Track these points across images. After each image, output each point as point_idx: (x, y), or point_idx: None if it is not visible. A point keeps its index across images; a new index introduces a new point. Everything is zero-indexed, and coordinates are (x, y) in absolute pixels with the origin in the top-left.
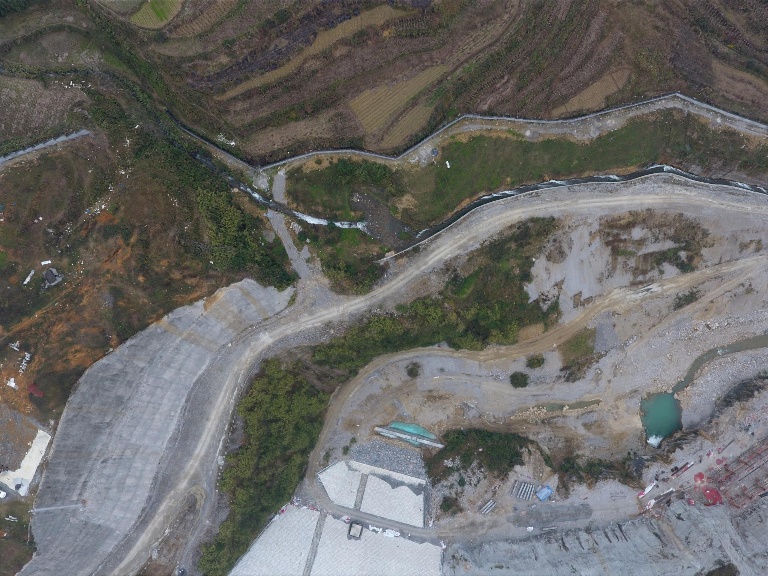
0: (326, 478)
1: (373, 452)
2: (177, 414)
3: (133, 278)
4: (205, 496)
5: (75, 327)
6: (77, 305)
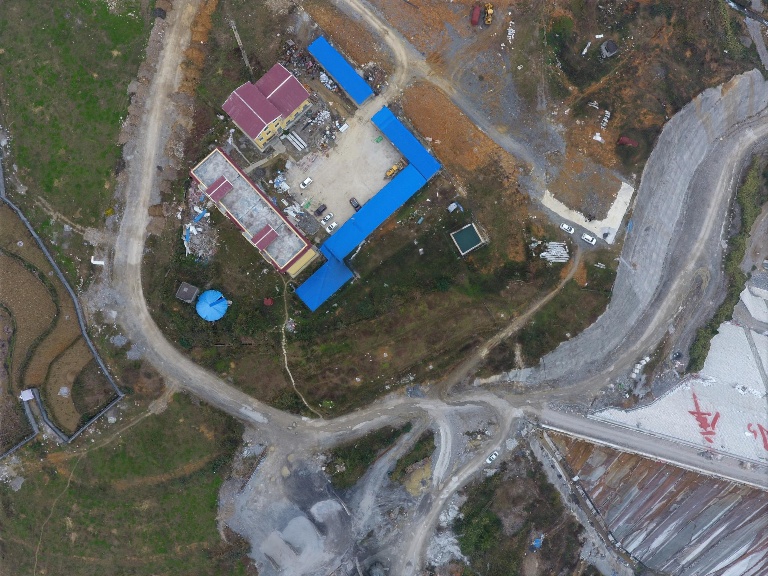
0: (743, 297)
1: (767, 282)
2: (682, 200)
3: (680, 53)
4: (710, 278)
5: (641, 92)
6: (633, 75)
